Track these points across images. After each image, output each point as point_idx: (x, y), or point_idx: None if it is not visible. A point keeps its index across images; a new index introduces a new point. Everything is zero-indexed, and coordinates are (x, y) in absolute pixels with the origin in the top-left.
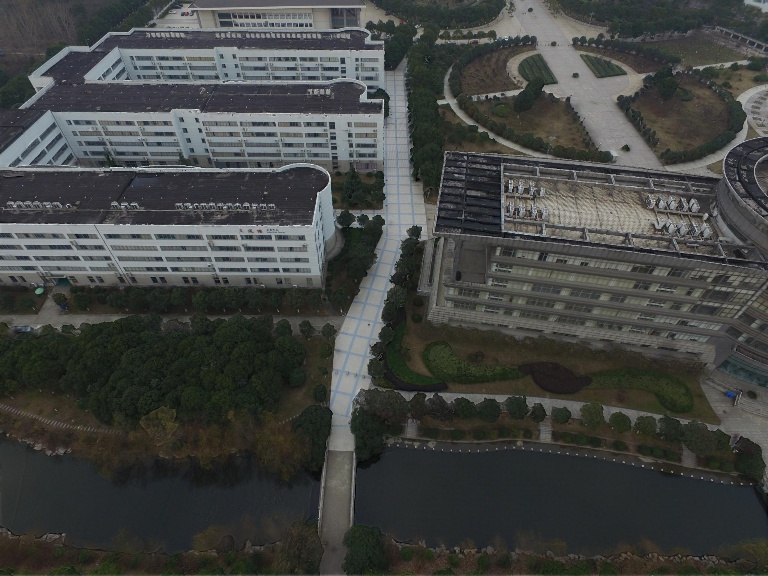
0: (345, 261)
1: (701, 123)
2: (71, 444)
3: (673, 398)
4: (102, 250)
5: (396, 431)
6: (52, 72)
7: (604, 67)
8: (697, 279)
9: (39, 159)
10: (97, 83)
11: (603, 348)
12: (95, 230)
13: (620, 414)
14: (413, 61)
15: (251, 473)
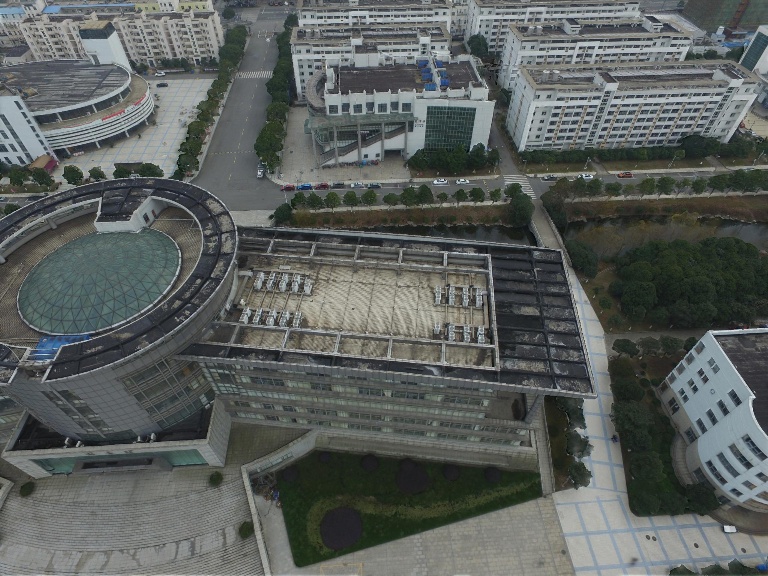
0: None
1: None
2: None
3: None
4: None
5: None
6: None
7: None
8: None
9: None
10: None
11: None
12: None
13: None
14: None
15: None
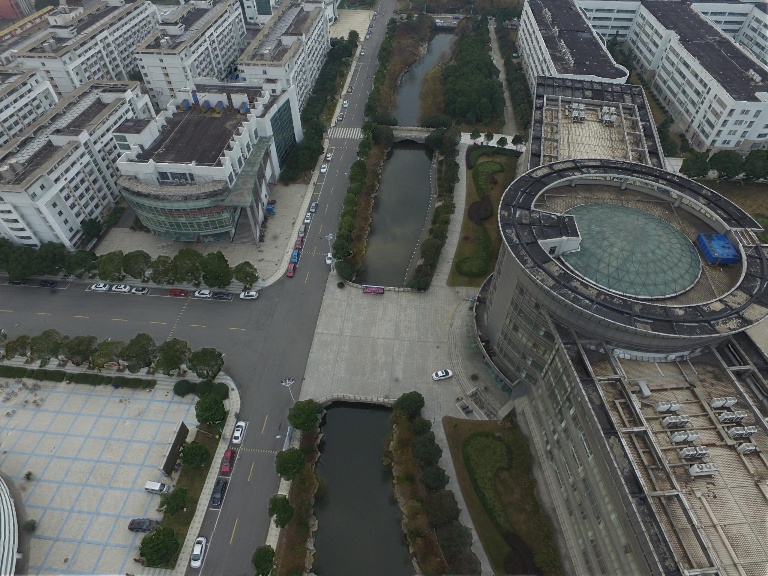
0: None
1: None
2: None
3: (467, 263)
4: None
5: (440, 150)
6: None
7: None
8: None
9: (604, 20)
10: (693, 10)
11: None
12: None
13: None
14: None
15: None
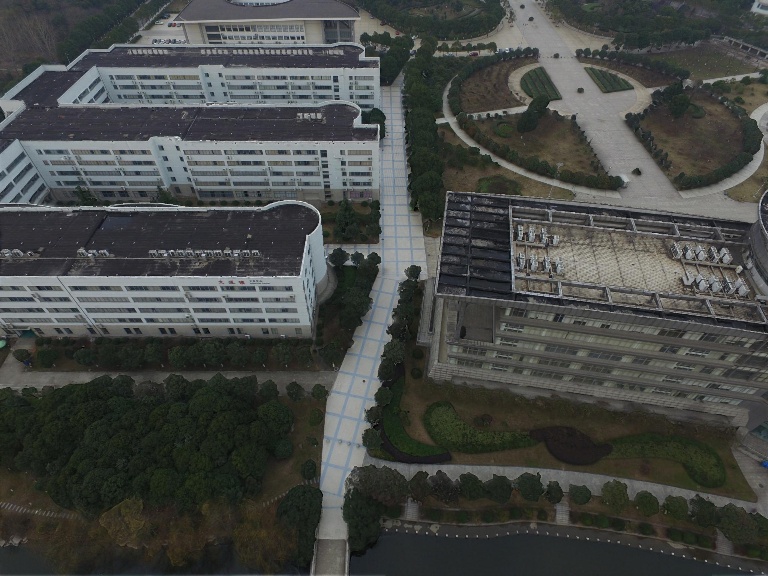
0: (338, 306)
1: (715, 143)
2: (27, 532)
3: (703, 470)
4: (68, 302)
5: (394, 514)
6: (24, 94)
7: (610, 81)
8: (733, 344)
9: (5, 193)
10: (72, 107)
11: (623, 409)
12: (58, 282)
13: (646, 495)
14: (410, 77)
15: (232, 559)
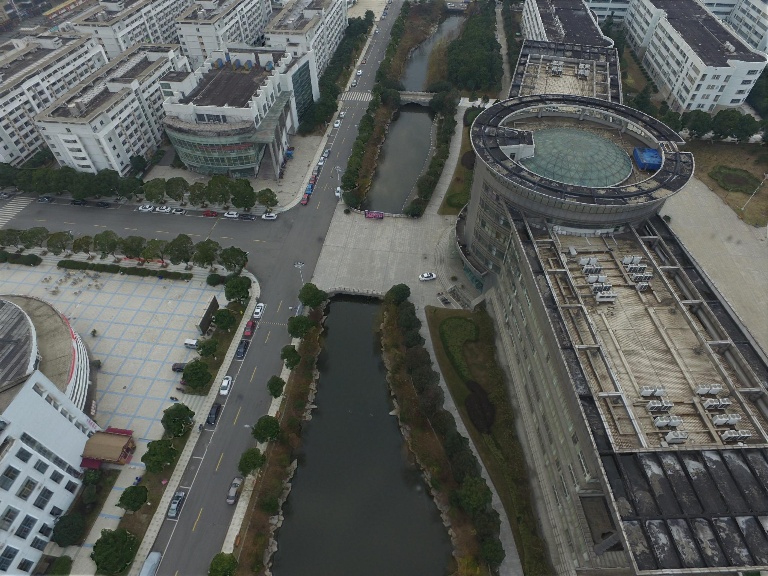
0: None
1: None
2: None
3: (456, 197)
4: None
5: None
6: None
7: None
8: None
9: (603, 2)
10: None
11: None
12: (535, 8)
13: None
14: None
15: None
